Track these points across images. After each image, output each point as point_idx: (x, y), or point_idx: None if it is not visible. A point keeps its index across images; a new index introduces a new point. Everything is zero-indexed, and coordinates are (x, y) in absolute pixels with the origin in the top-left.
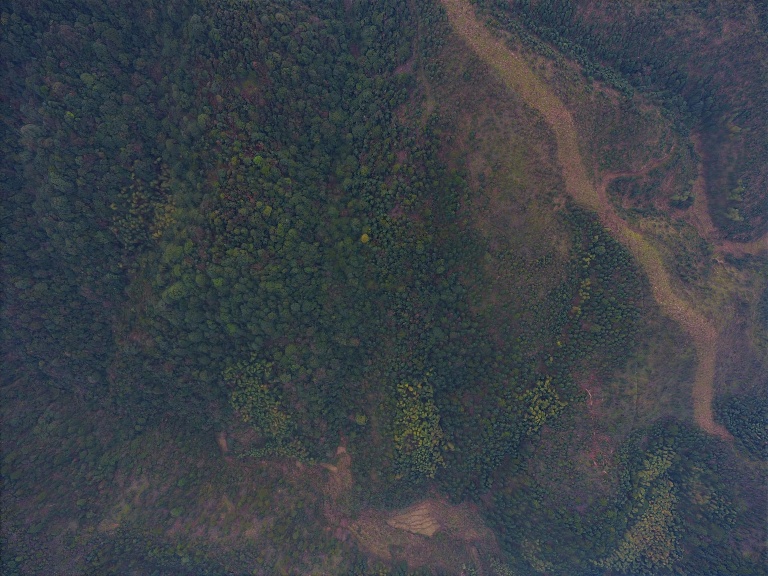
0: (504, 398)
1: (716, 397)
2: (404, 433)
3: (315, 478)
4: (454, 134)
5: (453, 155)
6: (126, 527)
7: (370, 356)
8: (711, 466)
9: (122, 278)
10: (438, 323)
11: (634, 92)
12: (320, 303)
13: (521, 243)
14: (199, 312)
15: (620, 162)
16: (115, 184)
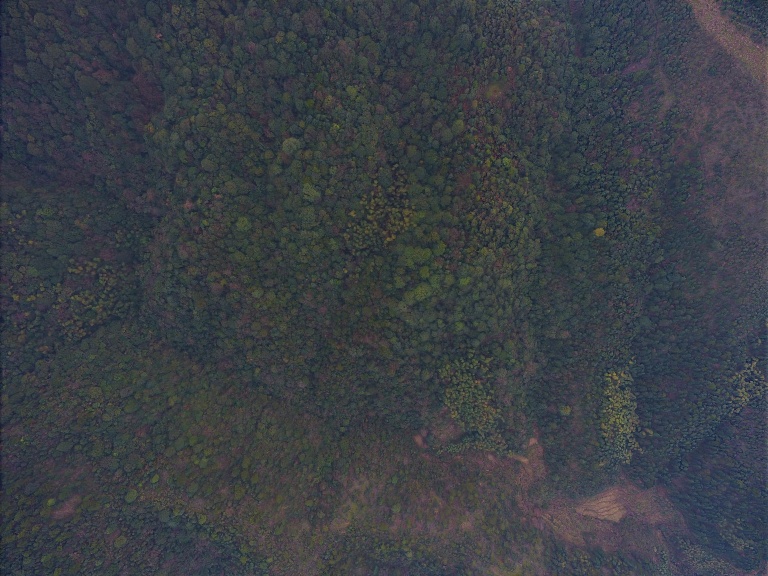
0: (713, 381)
1: None
2: (610, 421)
3: (508, 470)
4: (690, 127)
5: (687, 147)
6: (357, 525)
7: (576, 347)
8: None
9: (341, 283)
10: (647, 312)
11: None
12: (533, 298)
13: (755, 229)
14: (435, 312)
15: None
16: (360, 192)
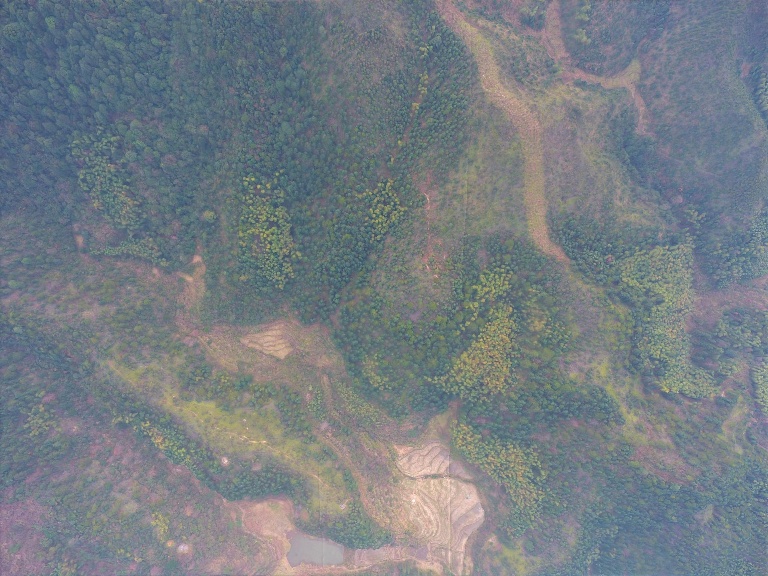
0: (344, 196)
1: (551, 212)
2: (249, 230)
3: (169, 285)
4: None
5: None
6: None
7: (220, 149)
8: (548, 290)
9: None
10: (285, 116)
11: None
12: (171, 85)
13: (350, 12)
14: (39, 64)
15: None
16: None
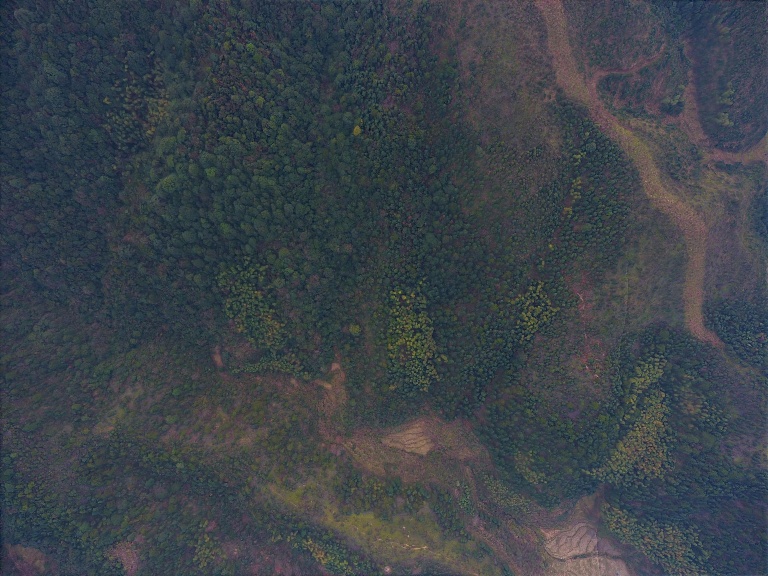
0: (496, 303)
1: (707, 301)
2: (397, 342)
3: (310, 395)
4: (445, 23)
5: (444, 45)
6: (121, 430)
7: (363, 264)
8: (702, 374)
9: (116, 183)
10: (431, 228)
11: None
12: (313, 208)
13: (512, 133)
14: (192, 208)
15: (610, 58)
16: (108, 76)
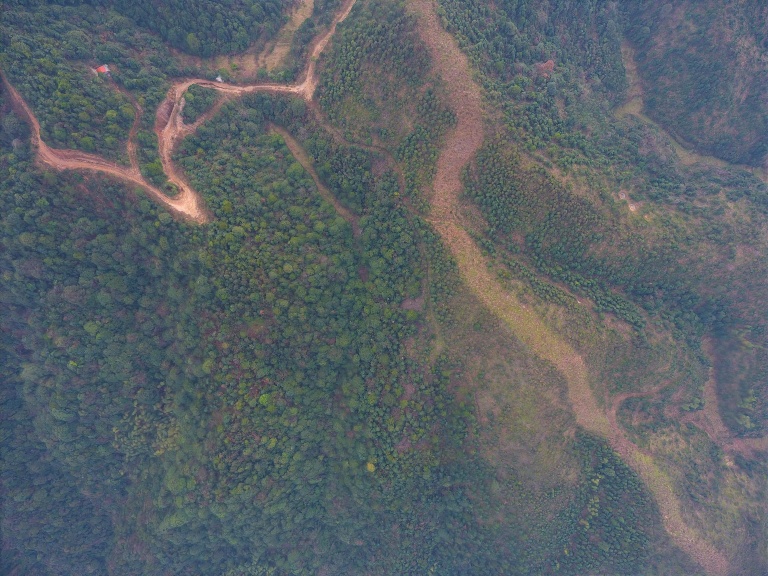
0: None
1: None
2: None
3: None
4: (463, 372)
5: (462, 390)
6: None
7: (374, 553)
8: None
9: (123, 479)
10: (443, 526)
11: None
12: (324, 506)
13: (530, 479)
14: (201, 532)
15: (631, 386)
16: (117, 412)
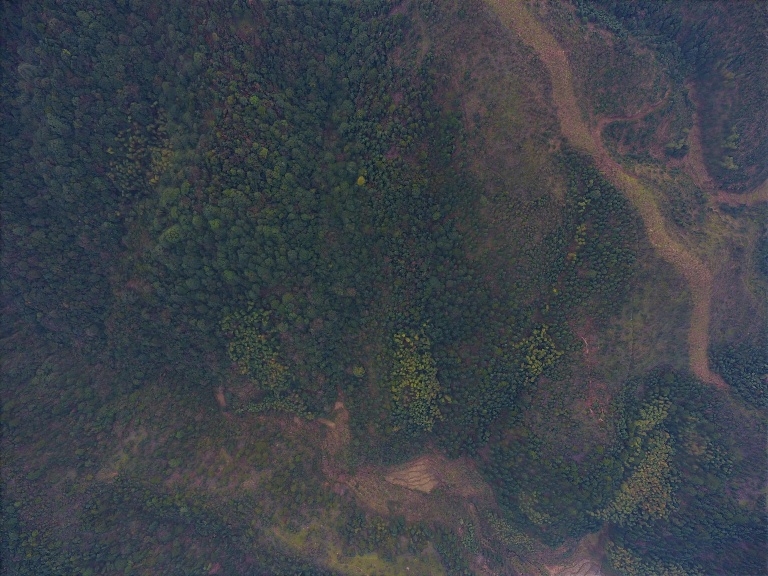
0: (501, 347)
1: (711, 345)
2: (401, 384)
3: (313, 434)
4: (449, 74)
5: (448, 96)
6: (124, 476)
7: (367, 307)
8: (707, 416)
9: (119, 228)
10: (435, 272)
11: (628, 35)
12: (317, 252)
13: (516, 184)
14: (196, 257)
15: (615, 106)
16: (112, 127)
